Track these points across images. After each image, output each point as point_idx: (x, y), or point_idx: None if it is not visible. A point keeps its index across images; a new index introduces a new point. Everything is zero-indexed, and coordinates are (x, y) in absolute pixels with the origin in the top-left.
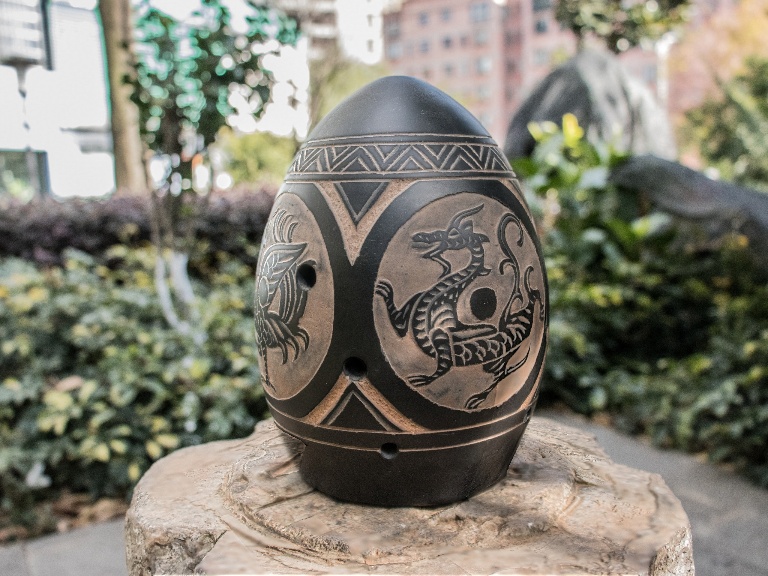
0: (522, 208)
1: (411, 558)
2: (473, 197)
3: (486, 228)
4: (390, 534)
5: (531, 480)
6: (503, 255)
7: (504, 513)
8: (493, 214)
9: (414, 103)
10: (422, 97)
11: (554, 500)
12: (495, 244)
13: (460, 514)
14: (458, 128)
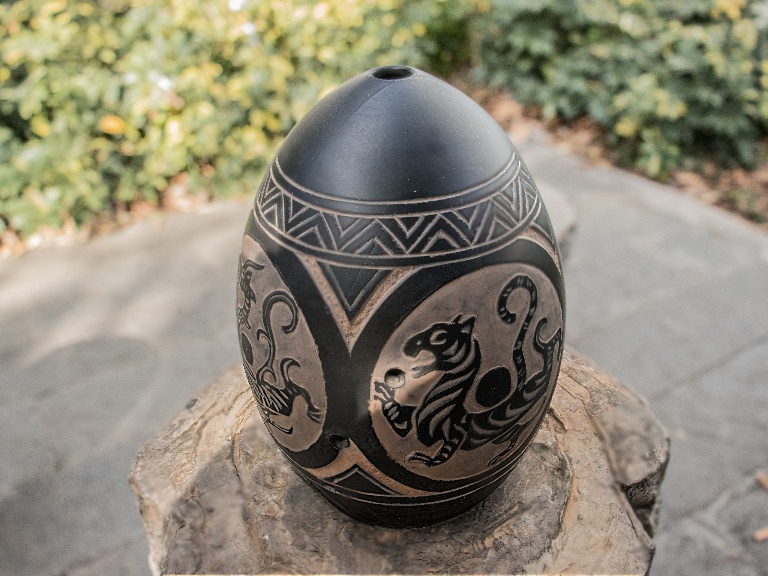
0: (319, 300)
1: (237, 459)
2: (262, 253)
3: (258, 289)
4: (266, 442)
5: (356, 547)
6: (263, 325)
7: (286, 517)
8: (268, 282)
9: (306, 124)
10: (319, 119)
11: (320, 567)
12: (260, 309)
13: (288, 485)
14: (300, 173)
